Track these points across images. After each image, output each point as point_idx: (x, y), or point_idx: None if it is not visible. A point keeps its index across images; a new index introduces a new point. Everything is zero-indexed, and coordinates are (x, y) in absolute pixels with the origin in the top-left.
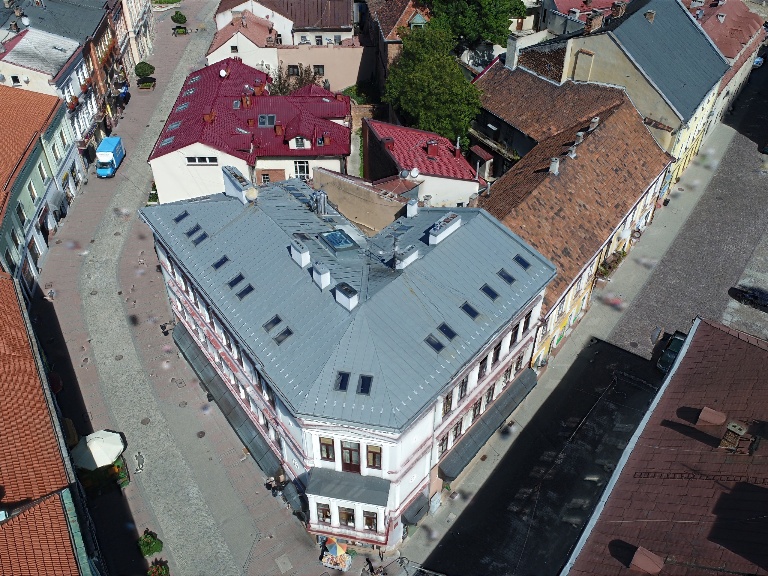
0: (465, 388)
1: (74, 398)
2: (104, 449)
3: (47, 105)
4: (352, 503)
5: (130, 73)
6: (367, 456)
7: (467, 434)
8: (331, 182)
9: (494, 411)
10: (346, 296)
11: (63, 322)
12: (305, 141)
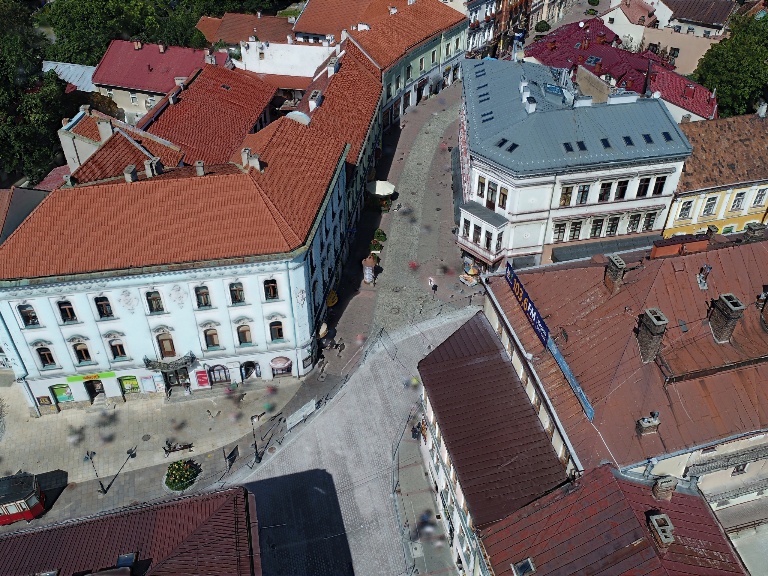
0: (586, 198)
1: (385, 171)
2: (383, 187)
3: (456, 18)
4: (481, 222)
5: (534, 29)
6: (500, 196)
7: (584, 244)
8: (585, 76)
9: (614, 243)
10: (529, 103)
11: (402, 139)
12: (612, 79)
